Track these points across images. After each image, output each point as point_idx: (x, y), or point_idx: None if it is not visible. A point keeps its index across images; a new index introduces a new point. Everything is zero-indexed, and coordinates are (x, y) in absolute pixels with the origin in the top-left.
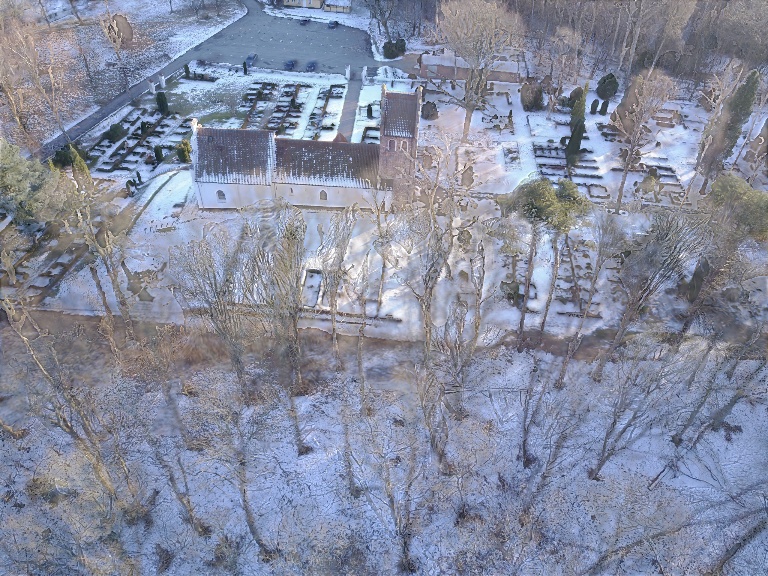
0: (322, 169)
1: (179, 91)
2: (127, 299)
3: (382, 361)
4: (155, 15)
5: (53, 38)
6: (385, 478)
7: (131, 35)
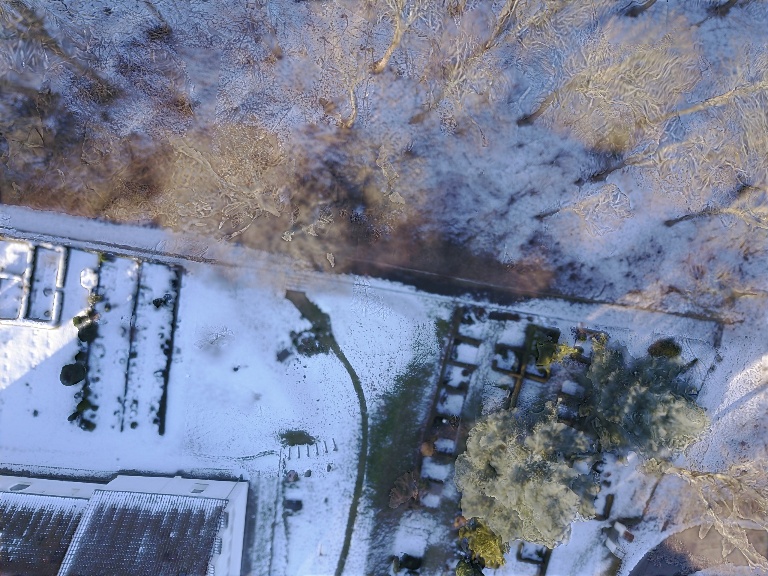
0: None
1: None
2: None
3: None
4: None
5: None
6: None
7: None
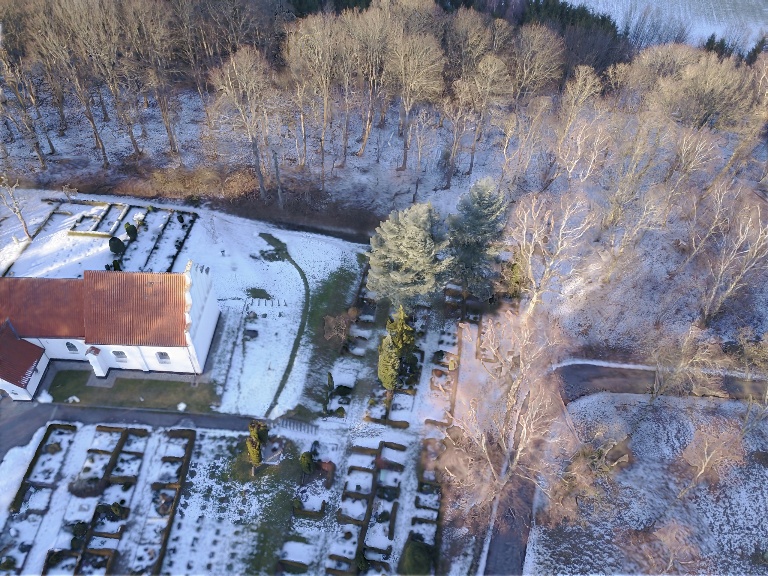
0: None
1: None
2: (253, 164)
3: (73, 173)
4: None
5: None
6: (100, 133)
7: None
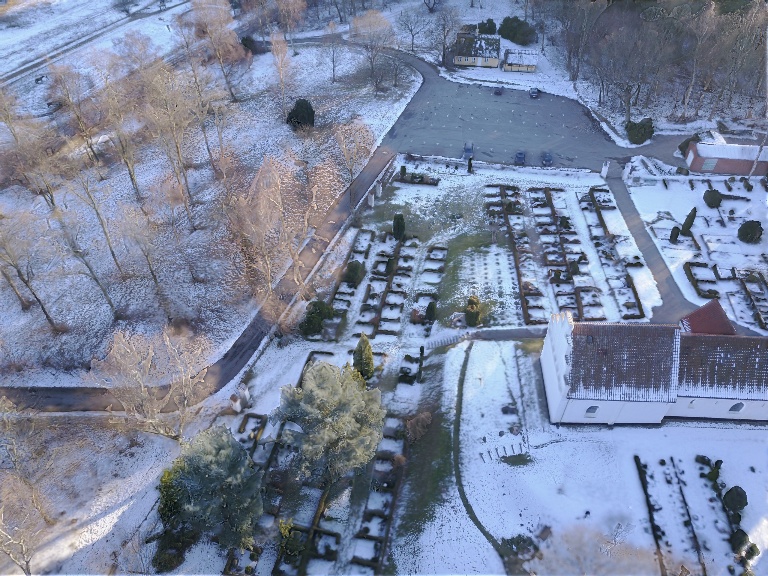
0: (744, 375)
1: (400, 201)
2: None
3: None
4: (314, 85)
5: (210, 122)
6: None
7: (313, 121)
